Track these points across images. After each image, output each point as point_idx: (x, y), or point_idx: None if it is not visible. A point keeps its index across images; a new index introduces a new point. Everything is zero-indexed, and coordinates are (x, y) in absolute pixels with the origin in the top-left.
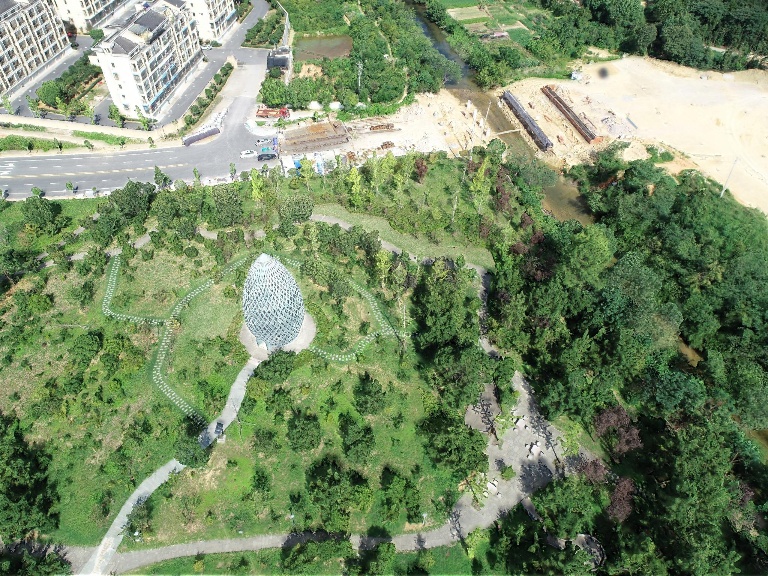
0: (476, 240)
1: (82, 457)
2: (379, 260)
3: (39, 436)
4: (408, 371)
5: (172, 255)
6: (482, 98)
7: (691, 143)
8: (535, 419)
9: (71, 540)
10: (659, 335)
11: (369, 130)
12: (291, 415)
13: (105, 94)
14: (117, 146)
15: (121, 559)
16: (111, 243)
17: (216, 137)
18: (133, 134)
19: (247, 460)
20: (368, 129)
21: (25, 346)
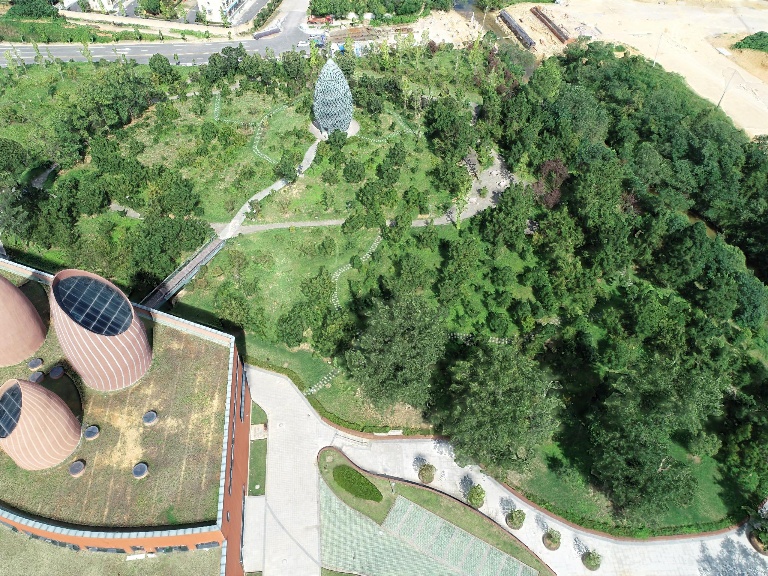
0: (471, 88)
1: (213, 185)
2: (402, 96)
3: (183, 176)
4: (421, 148)
5: (256, 94)
6: (483, 17)
7: (642, 43)
8: (504, 172)
9: (213, 220)
10: (593, 137)
11: (394, 32)
12: (345, 166)
13: (189, 8)
14: (204, 39)
15: (244, 228)
16: (212, 87)
17: (278, 35)
18: (216, 31)
19: (318, 186)
20: (393, 31)
21: (165, 135)
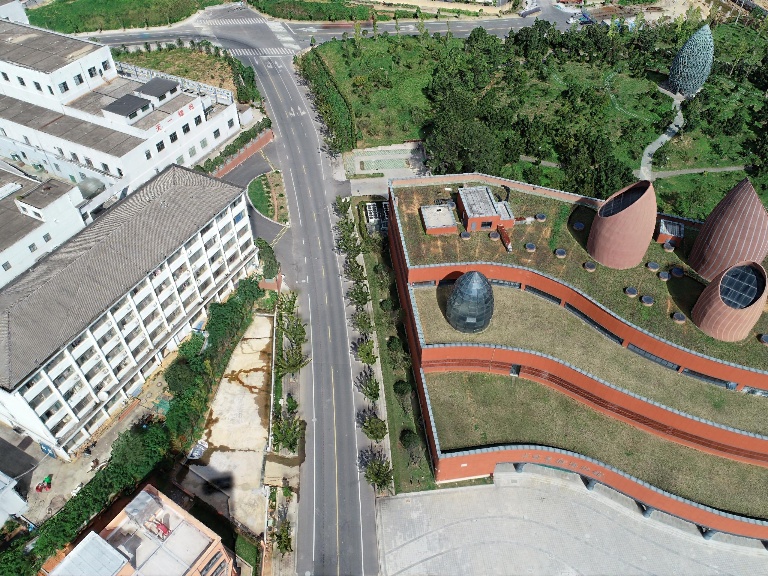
0: None
1: None
2: None
3: None
4: None
5: (576, 63)
6: None
7: None
8: None
9: None
10: None
11: (646, 10)
12: None
13: None
14: (475, 17)
15: (657, 174)
16: None
17: (540, 13)
18: (484, 9)
19: (702, 139)
20: (645, 10)
21: (525, 98)
